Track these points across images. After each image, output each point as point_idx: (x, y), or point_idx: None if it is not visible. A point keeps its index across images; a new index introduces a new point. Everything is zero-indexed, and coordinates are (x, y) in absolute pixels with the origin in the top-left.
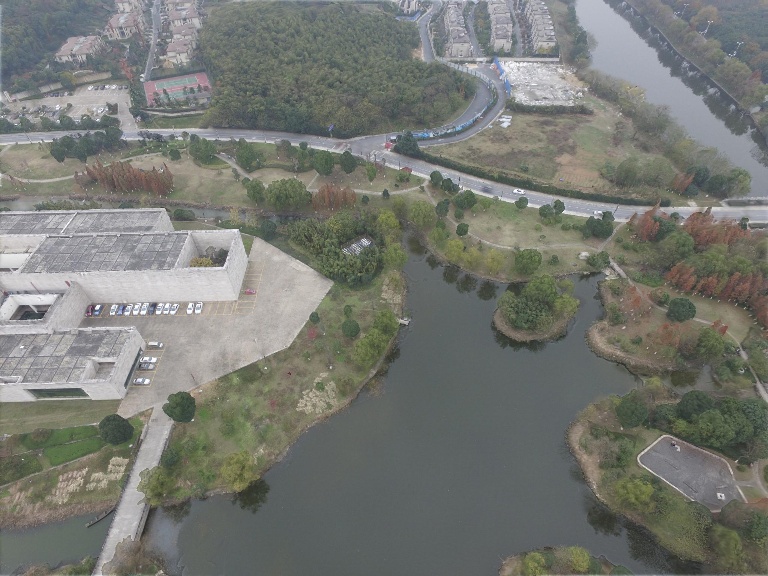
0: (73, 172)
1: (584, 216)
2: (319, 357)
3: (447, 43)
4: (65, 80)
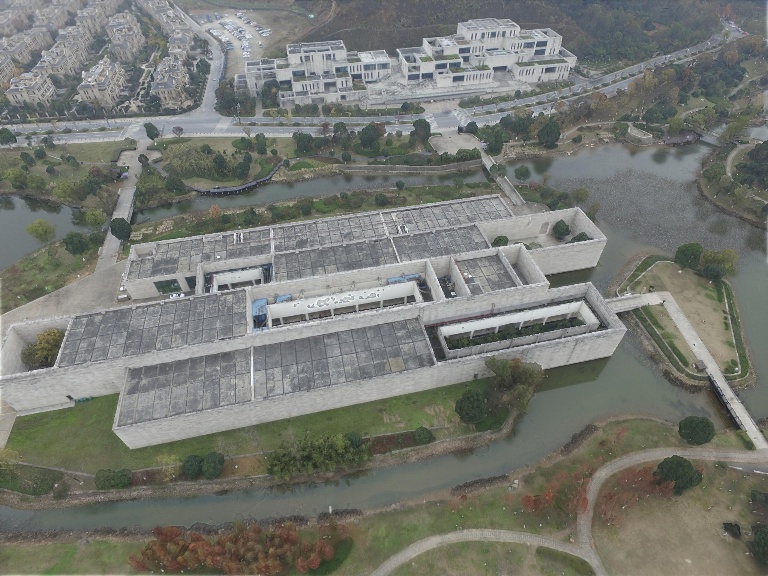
0: None
1: None
2: None
3: None
4: None
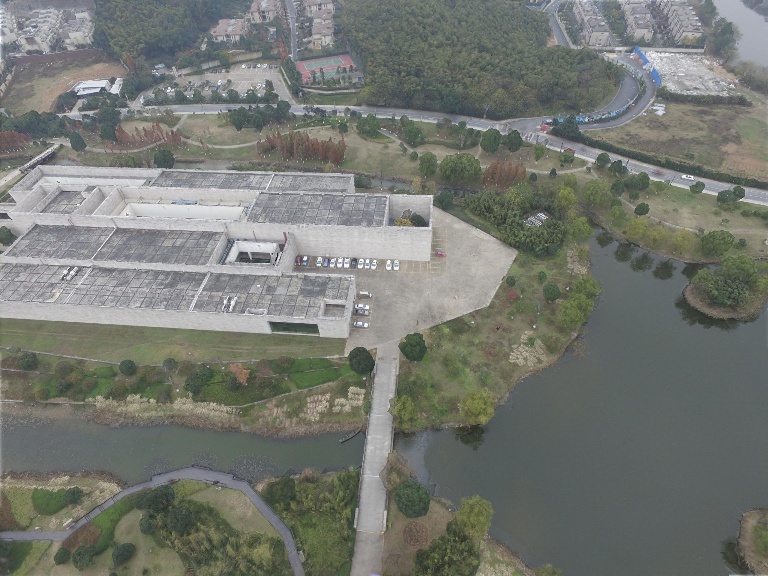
0: (250, 140)
1: (762, 204)
2: (520, 317)
3: (581, 32)
4: (224, 58)
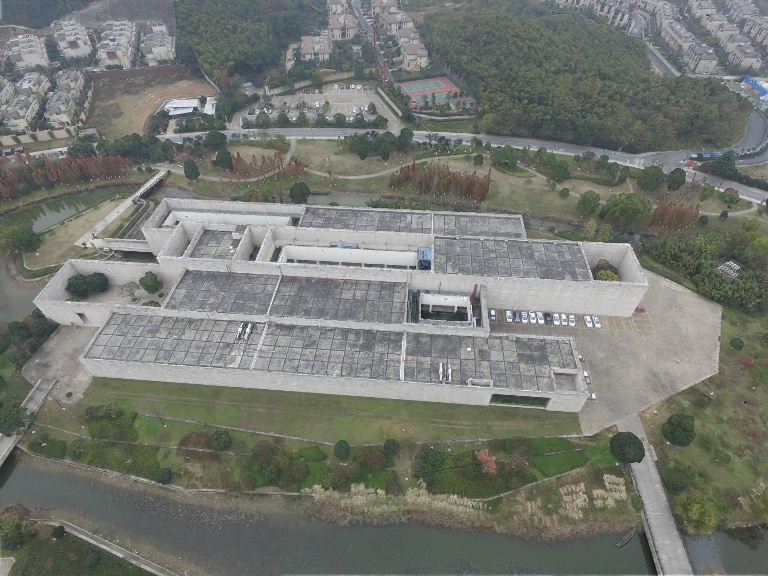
0: (375, 170)
1: None
2: (760, 387)
3: (681, 59)
4: (318, 78)
